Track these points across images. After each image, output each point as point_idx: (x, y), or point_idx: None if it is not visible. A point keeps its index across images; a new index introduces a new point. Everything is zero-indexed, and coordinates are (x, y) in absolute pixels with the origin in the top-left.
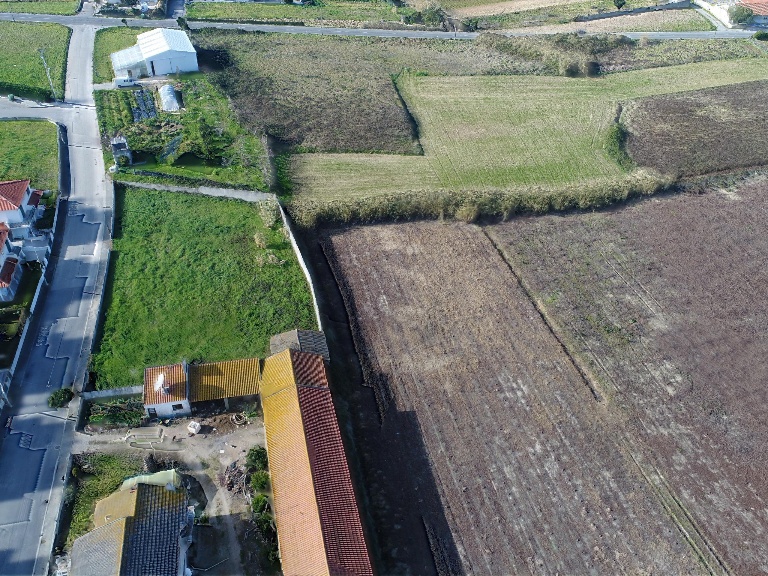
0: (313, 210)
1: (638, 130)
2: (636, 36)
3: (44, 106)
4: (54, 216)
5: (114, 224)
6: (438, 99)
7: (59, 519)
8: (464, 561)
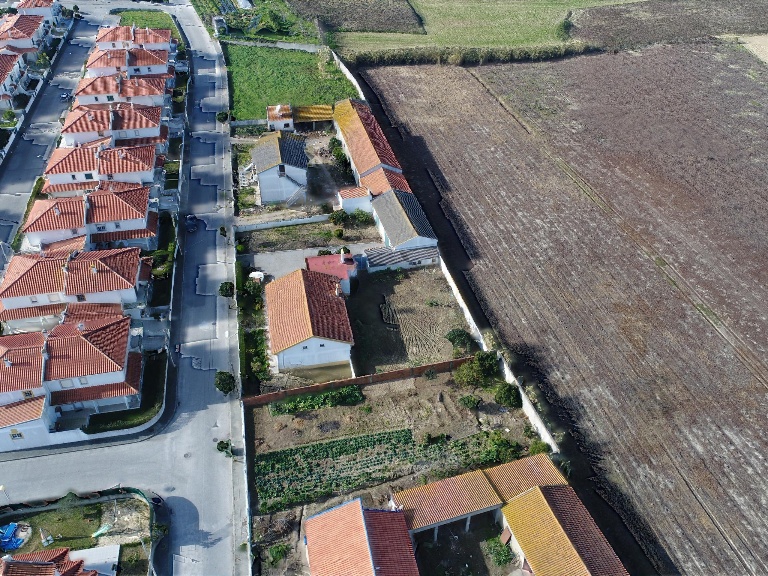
0: (354, 54)
1: (581, 24)
2: None
3: (156, 4)
4: None
5: (225, 60)
6: (437, 6)
7: (232, 163)
8: (449, 181)
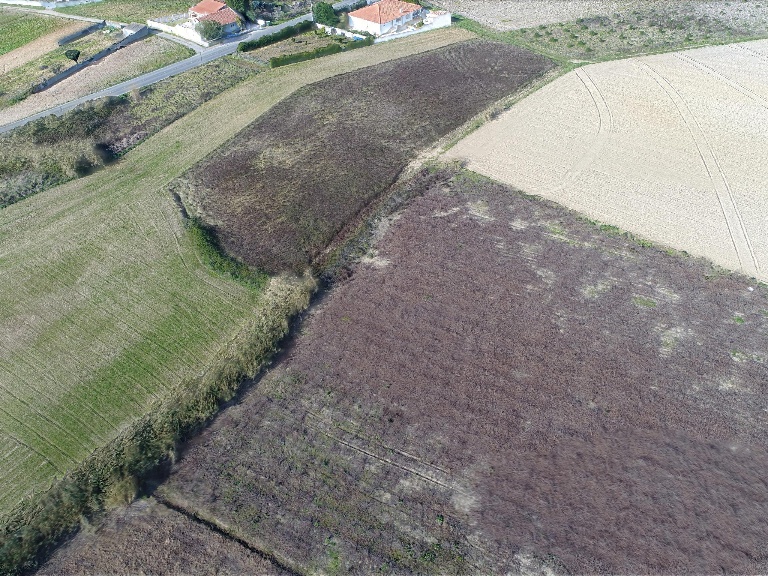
0: None
1: (219, 218)
2: (120, 90)
3: None
4: None
5: None
6: None
7: None
8: None
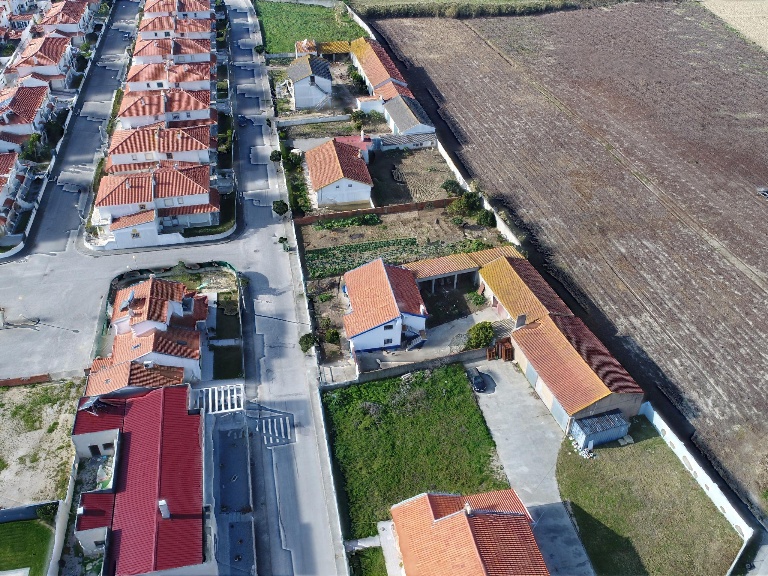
0: (365, 8)
1: None
2: None
3: None
4: (222, 7)
5: None
6: None
7: (269, 83)
8: (445, 96)
